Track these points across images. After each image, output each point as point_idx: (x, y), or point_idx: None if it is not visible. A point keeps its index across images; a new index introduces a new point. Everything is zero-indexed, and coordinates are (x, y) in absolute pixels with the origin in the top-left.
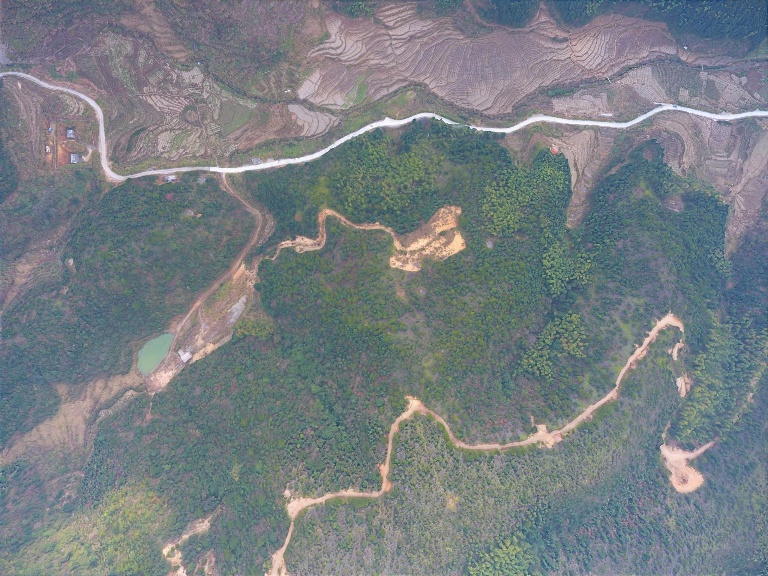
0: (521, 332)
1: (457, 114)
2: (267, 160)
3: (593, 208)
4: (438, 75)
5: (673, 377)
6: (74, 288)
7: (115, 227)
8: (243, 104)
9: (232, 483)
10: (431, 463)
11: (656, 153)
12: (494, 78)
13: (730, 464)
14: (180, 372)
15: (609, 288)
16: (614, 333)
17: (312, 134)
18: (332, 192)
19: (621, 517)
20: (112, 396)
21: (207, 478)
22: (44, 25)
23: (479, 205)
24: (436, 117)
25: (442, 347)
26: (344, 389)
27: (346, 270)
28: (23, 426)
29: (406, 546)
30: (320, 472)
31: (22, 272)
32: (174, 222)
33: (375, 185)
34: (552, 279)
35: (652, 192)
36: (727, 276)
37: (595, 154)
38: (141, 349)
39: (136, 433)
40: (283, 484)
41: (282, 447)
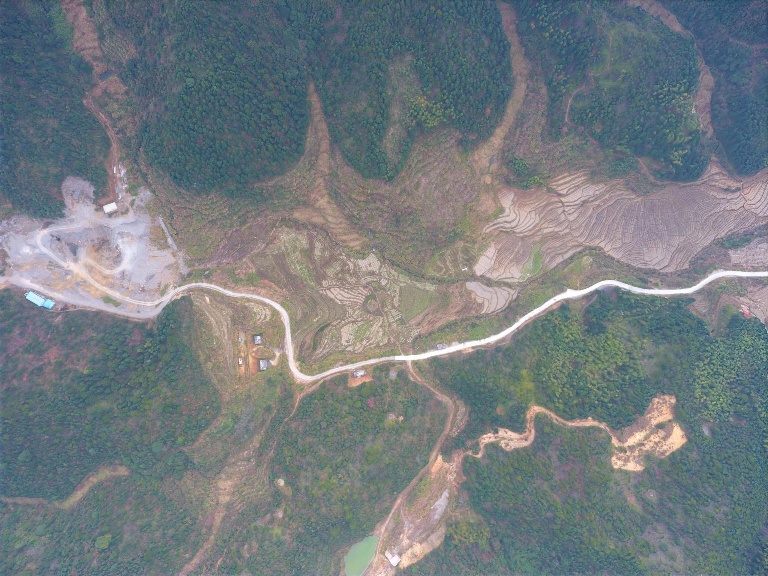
0: None
1: (636, 276)
2: (452, 344)
3: None
4: (612, 237)
5: None
6: (293, 515)
7: (329, 449)
8: (422, 287)
9: None
10: None
11: None
12: (669, 235)
13: None
14: None
15: None
16: None
17: (492, 311)
18: (539, 388)
19: None
20: None
21: None
22: (219, 228)
23: (691, 390)
24: (618, 284)
25: (701, 572)
26: None
27: (572, 478)
28: None
29: None
30: None
31: (224, 489)
32: (382, 432)
33: (579, 374)
34: None
35: None
36: None
37: None
38: (347, 554)
39: None
40: None
41: None
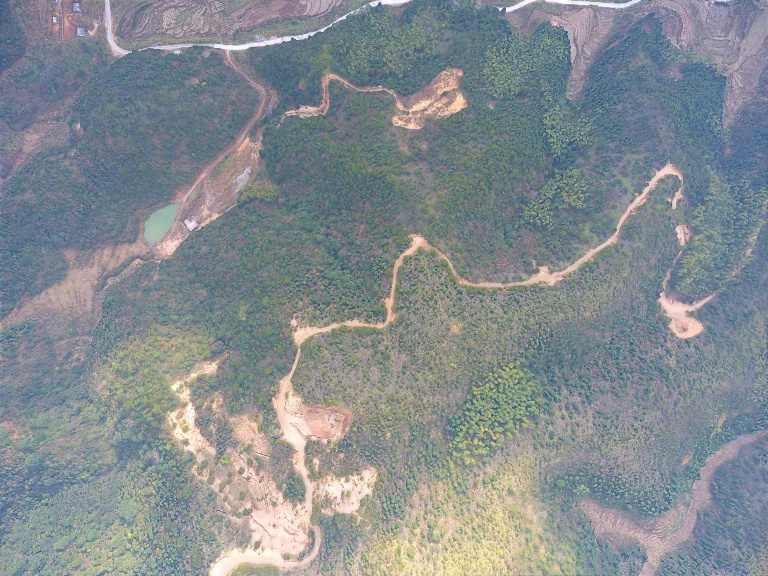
0: (522, 186)
1: None
2: (270, 37)
3: (592, 79)
4: None
5: (672, 223)
6: (82, 147)
7: (122, 87)
8: None
9: (239, 325)
10: (435, 290)
11: (654, 28)
12: None
13: (729, 312)
14: (186, 238)
15: (609, 148)
16: (614, 184)
17: (315, 13)
18: (335, 57)
19: (622, 359)
20: (119, 264)
21: (214, 327)
22: None
23: (480, 69)
24: None
25: (445, 186)
26: (349, 235)
27: (350, 126)
28: (32, 288)
29: (411, 366)
30: (326, 306)
31: (30, 141)
32: (180, 87)
33: (377, 52)
34: (553, 138)
35: (651, 62)
36: (725, 142)
37: (594, 33)
38: (148, 219)
39: (144, 290)
40: (290, 314)
41: (288, 283)
